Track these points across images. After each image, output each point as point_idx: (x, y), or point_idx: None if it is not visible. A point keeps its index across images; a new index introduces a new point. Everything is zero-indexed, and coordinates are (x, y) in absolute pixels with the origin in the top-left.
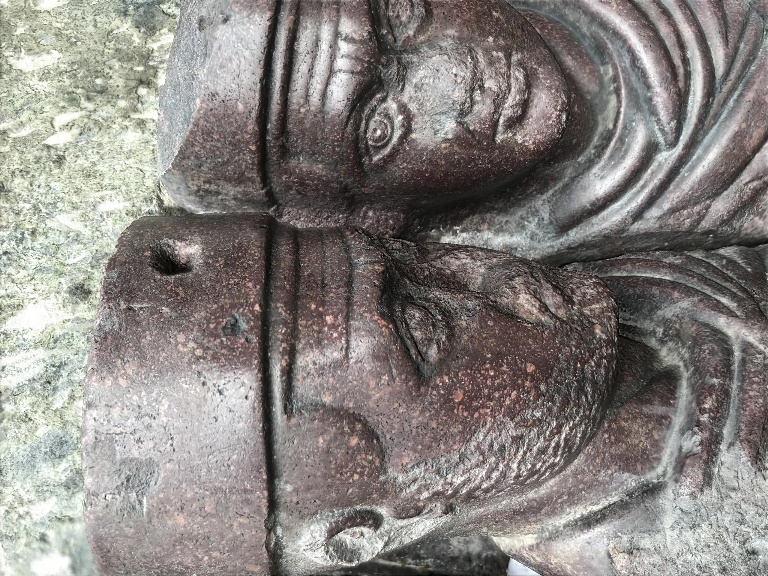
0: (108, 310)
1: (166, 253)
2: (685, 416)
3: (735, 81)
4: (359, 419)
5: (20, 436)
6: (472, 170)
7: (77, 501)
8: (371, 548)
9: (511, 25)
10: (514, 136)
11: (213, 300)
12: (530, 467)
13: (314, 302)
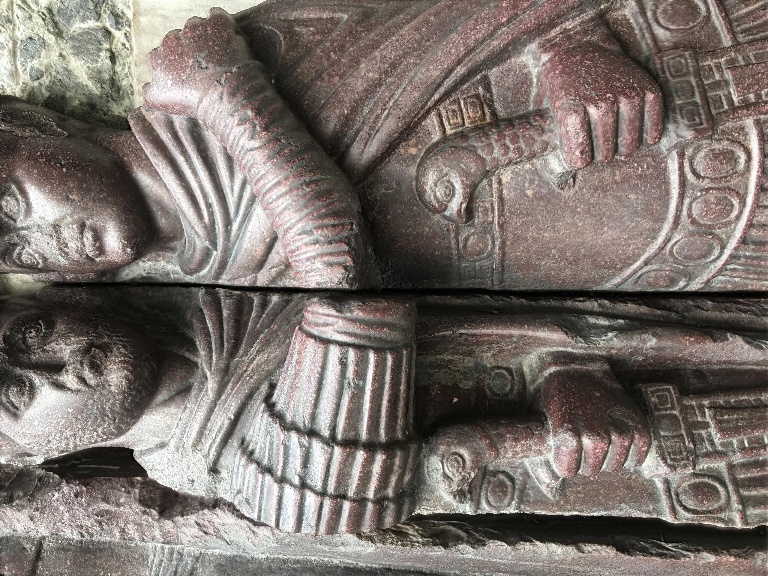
0: None
1: None
2: None
3: (242, 217)
4: None
5: None
6: (94, 270)
7: None
8: (39, 460)
9: (83, 202)
10: (106, 258)
11: None
12: (88, 442)
13: None
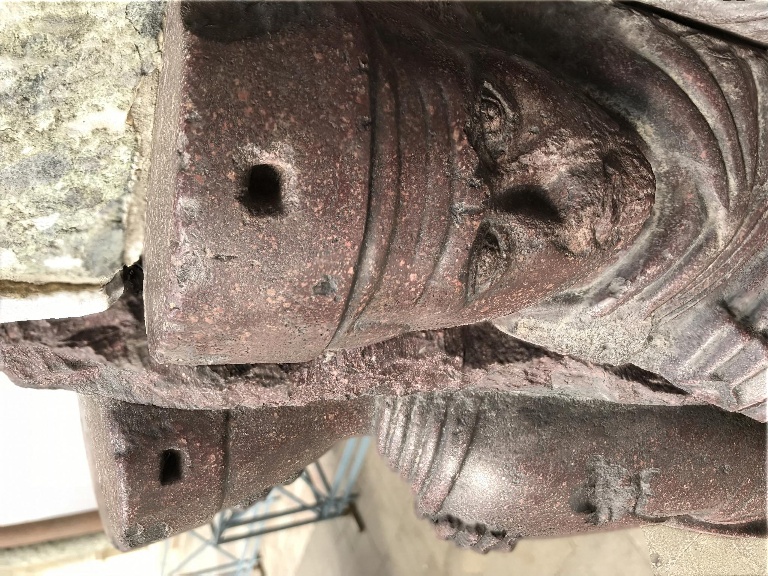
0: (193, 257)
1: (250, 164)
2: (629, 263)
3: None
4: (402, 326)
5: (4, 155)
6: None
7: (81, 215)
8: None
9: None
10: None
11: (308, 257)
12: None
13: (404, 258)
